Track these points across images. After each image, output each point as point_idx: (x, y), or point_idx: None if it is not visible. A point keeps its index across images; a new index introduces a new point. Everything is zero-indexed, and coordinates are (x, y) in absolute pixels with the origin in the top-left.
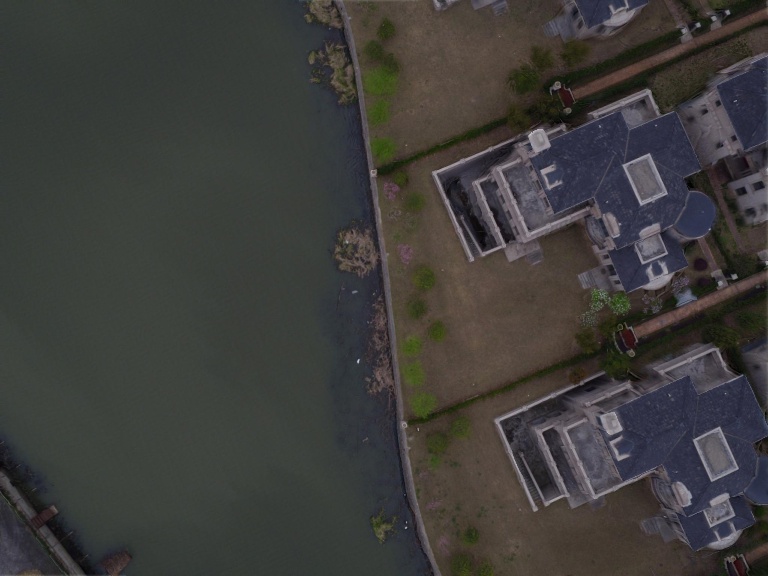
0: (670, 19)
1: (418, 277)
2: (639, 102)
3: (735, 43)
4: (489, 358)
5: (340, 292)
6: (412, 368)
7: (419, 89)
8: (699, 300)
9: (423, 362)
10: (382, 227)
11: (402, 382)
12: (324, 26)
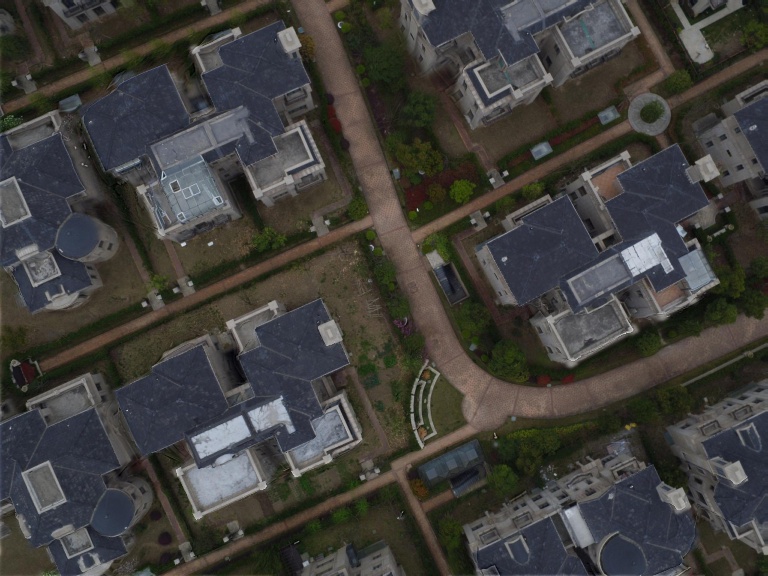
0: (141, 286)
1: None
2: (82, 386)
3: (207, 310)
4: None
5: None
6: None
7: None
8: (166, 573)
9: None
10: None
11: None
12: None
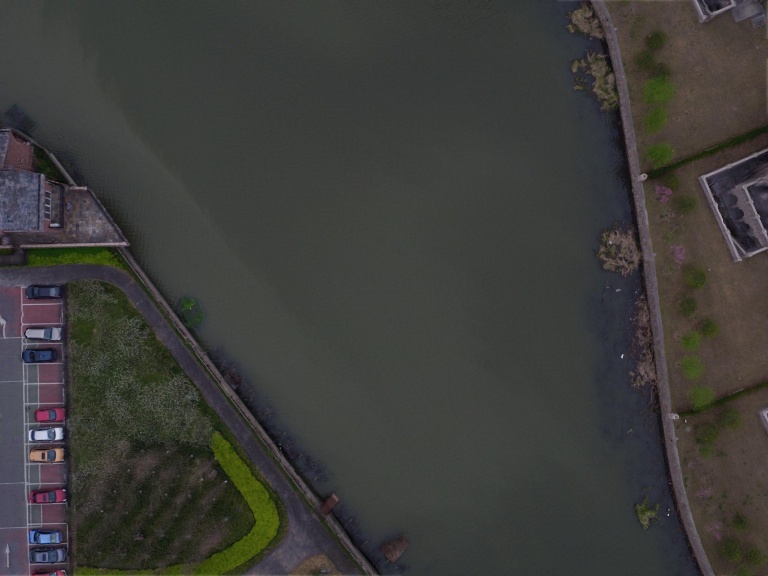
0: None
1: (692, 276)
2: None
3: None
4: (754, 353)
5: (604, 290)
6: (679, 363)
7: (684, 97)
8: None
9: (690, 357)
10: (649, 228)
11: (670, 376)
12: (586, 36)
